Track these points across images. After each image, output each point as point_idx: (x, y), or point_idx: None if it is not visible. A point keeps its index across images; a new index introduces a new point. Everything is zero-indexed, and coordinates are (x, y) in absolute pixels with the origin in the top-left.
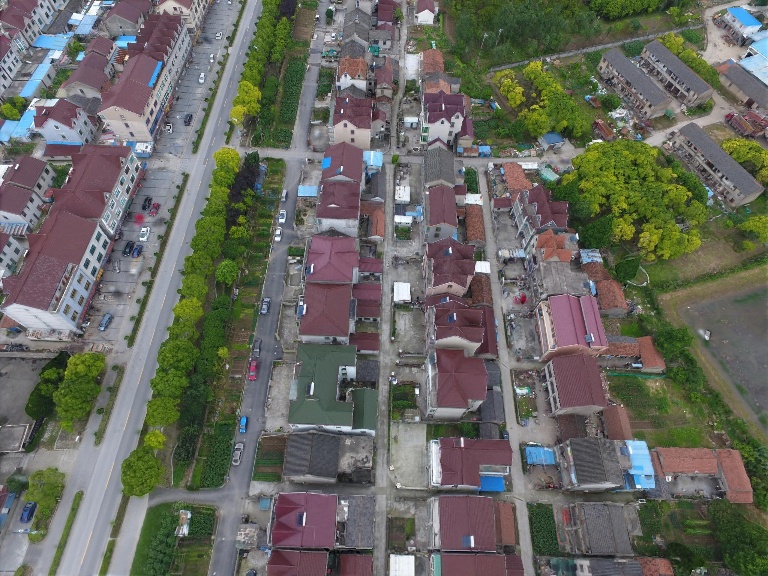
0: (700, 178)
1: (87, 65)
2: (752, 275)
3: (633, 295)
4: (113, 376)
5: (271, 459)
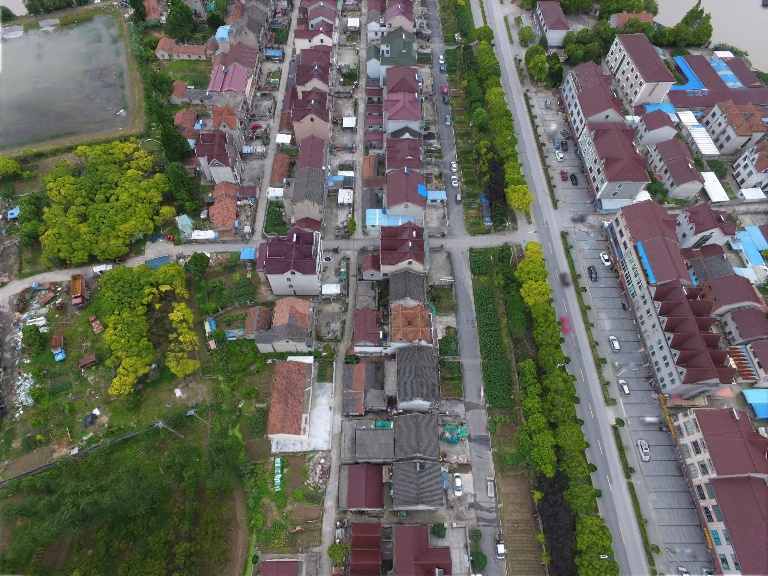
0: (1, 239)
1: (753, 310)
2: (43, 146)
3: None
4: (526, 81)
5: (423, 59)
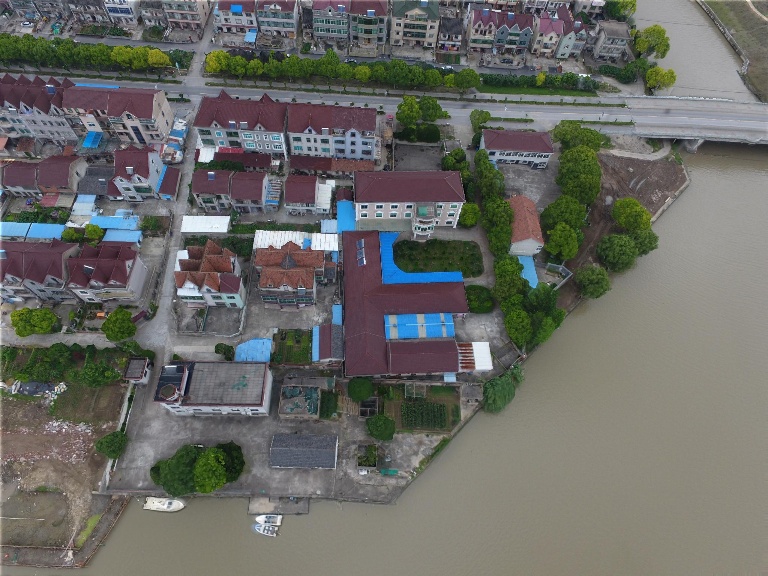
0: None
1: None
2: None
3: None
4: None
5: (448, 58)
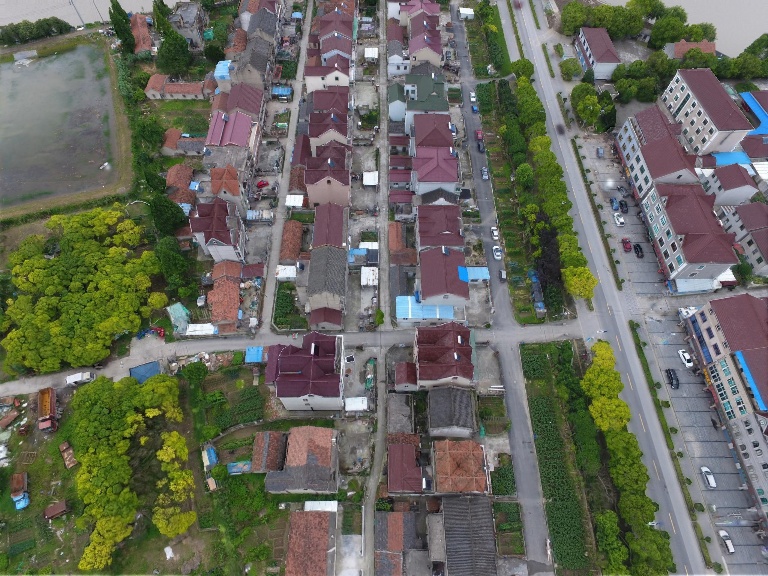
0: None
1: None
2: (12, 212)
3: (152, 193)
4: (572, 124)
5: (452, 96)
